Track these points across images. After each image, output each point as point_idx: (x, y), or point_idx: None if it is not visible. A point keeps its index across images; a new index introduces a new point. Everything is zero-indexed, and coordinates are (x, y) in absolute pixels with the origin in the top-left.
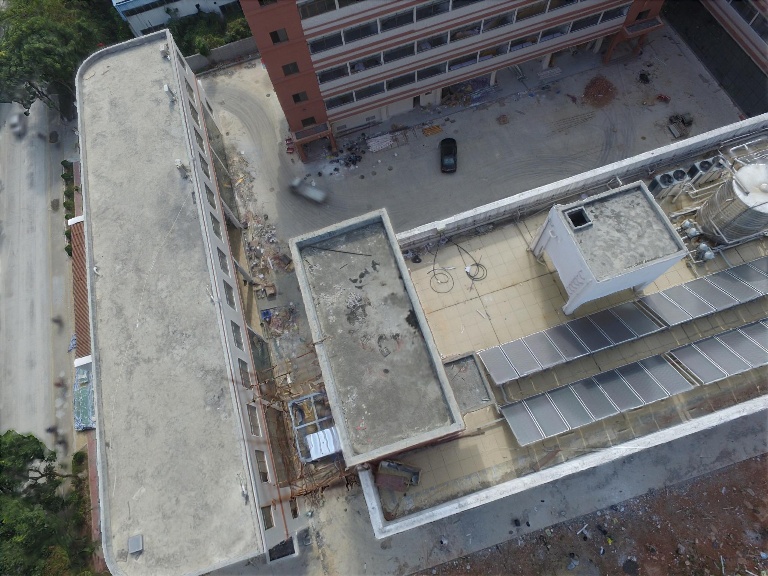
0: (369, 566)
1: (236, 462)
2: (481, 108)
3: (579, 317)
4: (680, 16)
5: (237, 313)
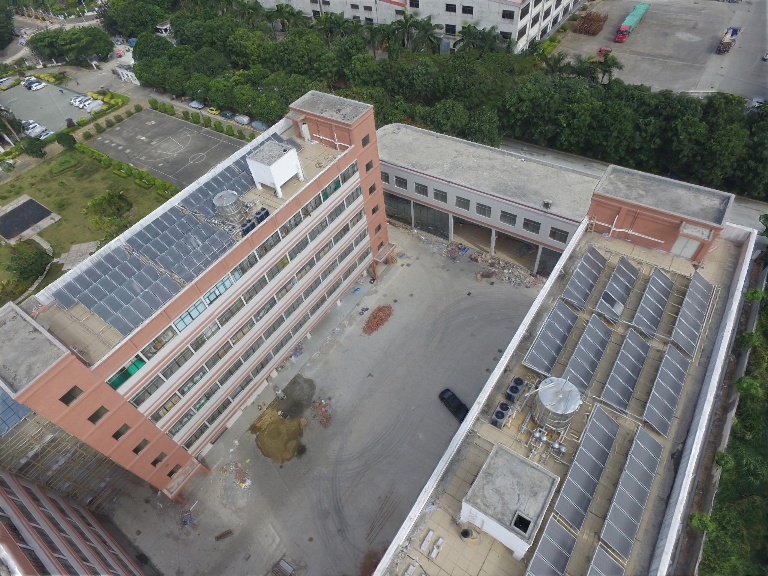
0: None
1: None
2: None
3: None
4: None
5: (454, 206)
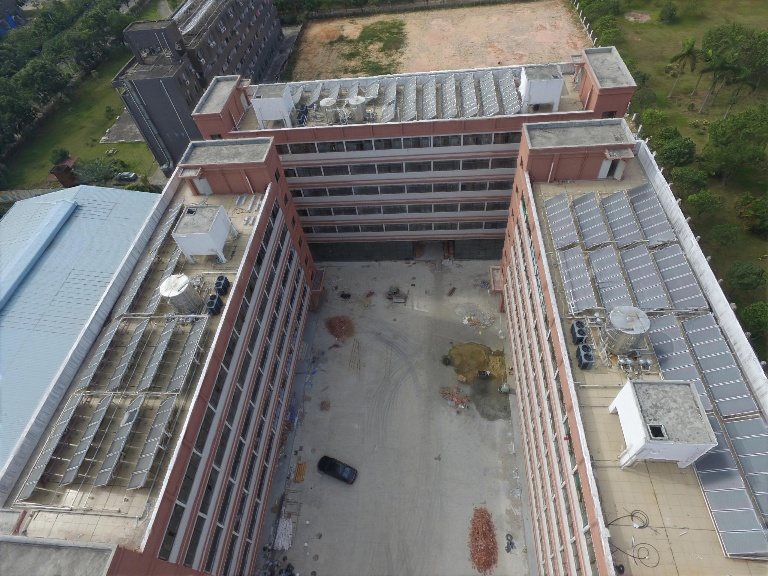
0: None
1: None
2: (302, 418)
3: None
4: (313, 255)
5: None
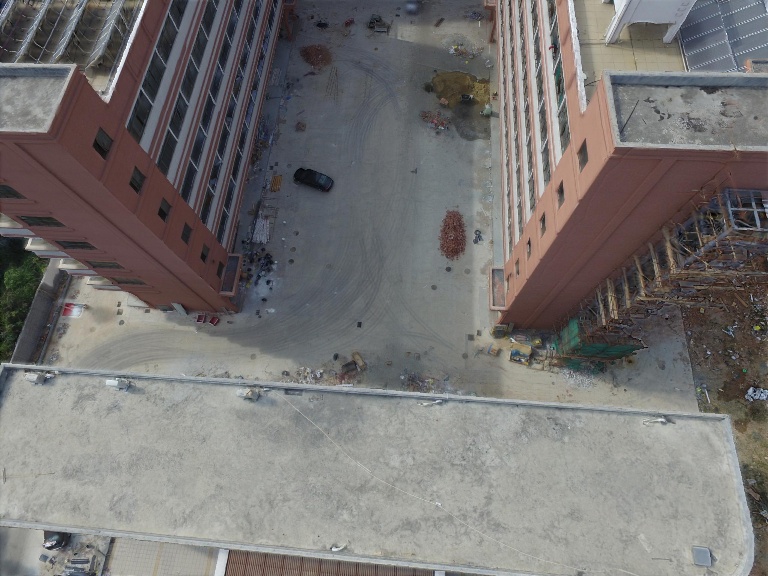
0: (677, 385)
1: (631, 423)
2: (277, 138)
3: (677, 35)
4: None
5: None
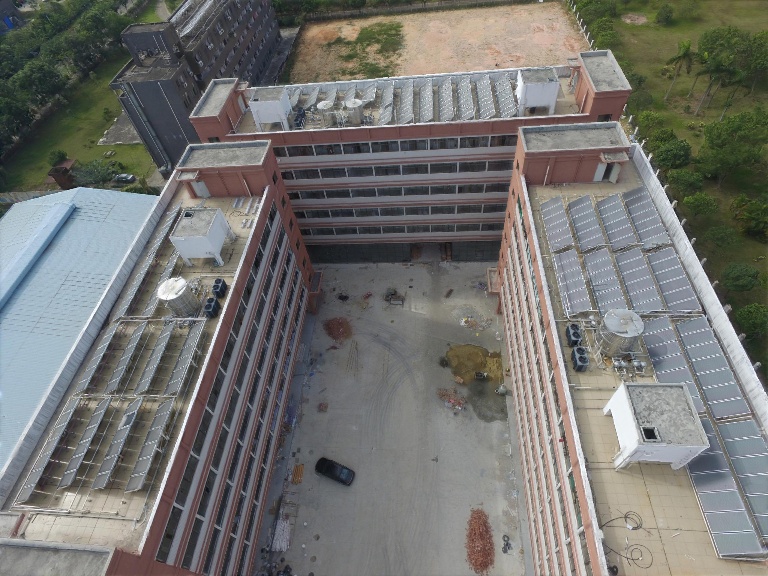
0: None
1: None
2: (300, 419)
3: None
4: (311, 257)
5: None
